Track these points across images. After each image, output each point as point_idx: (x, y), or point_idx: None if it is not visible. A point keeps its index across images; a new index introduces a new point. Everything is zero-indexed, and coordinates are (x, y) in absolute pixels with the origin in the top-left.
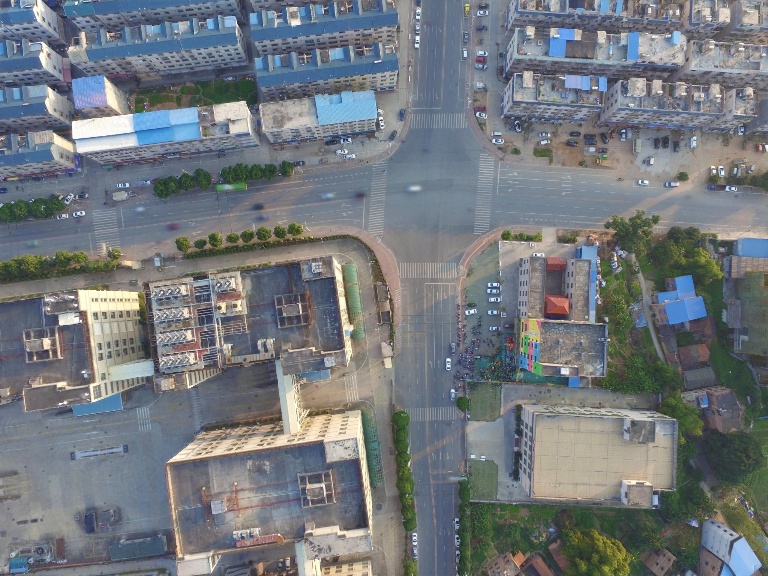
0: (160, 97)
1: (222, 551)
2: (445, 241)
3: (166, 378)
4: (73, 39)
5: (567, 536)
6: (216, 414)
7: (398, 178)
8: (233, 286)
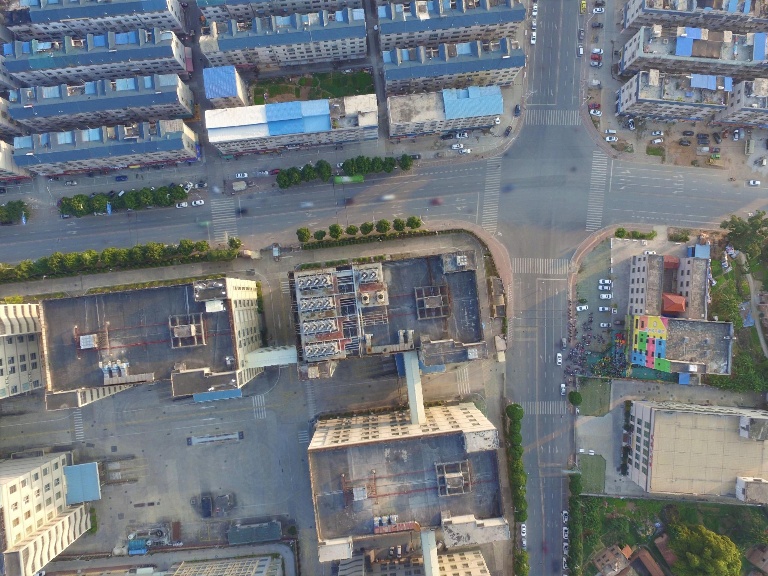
0: (279, 88)
1: (360, 537)
2: (557, 237)
3: (311, 366)
4: (203, 29)
5: (676, 531)
6: (330, 403)
7: (512, 174)
8: (378, 277)
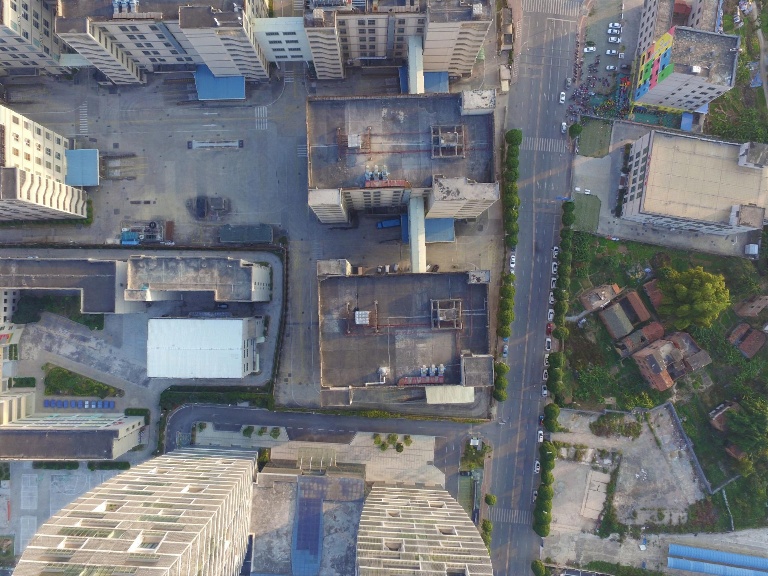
0: None
1: (351, 190)
2: None
3: None
4: None
5: (666, 269)
6: None
7: None
8: None
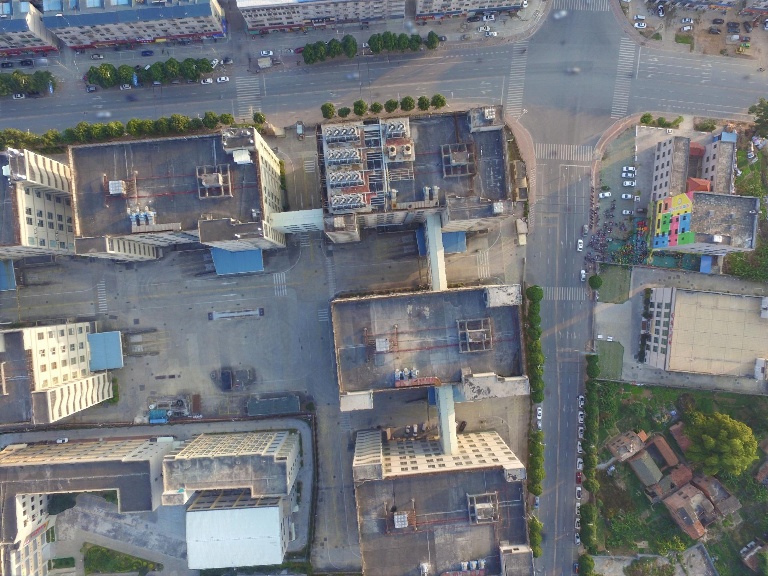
0: None
1: (381, 390)
2: (582, 124)
3: (337, 217)
4: None
5: (692, 416)
6: (350, 283)
7: (538, 58)
8: (405, 130)
